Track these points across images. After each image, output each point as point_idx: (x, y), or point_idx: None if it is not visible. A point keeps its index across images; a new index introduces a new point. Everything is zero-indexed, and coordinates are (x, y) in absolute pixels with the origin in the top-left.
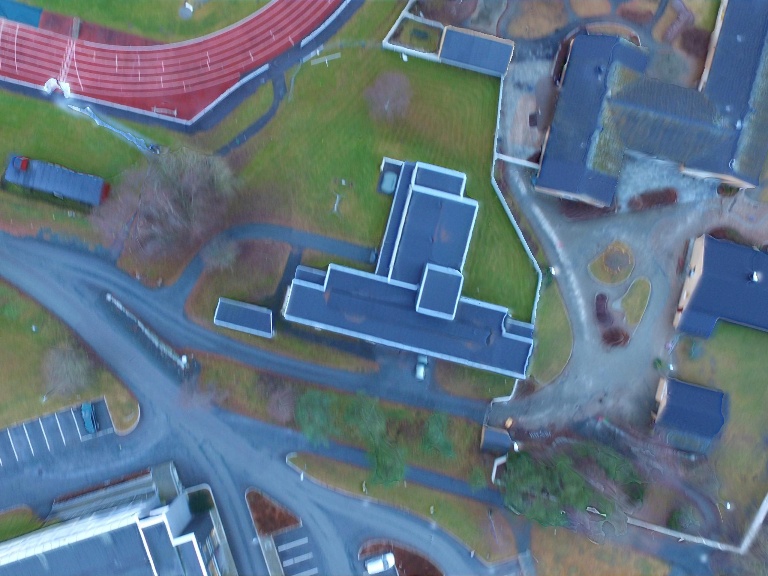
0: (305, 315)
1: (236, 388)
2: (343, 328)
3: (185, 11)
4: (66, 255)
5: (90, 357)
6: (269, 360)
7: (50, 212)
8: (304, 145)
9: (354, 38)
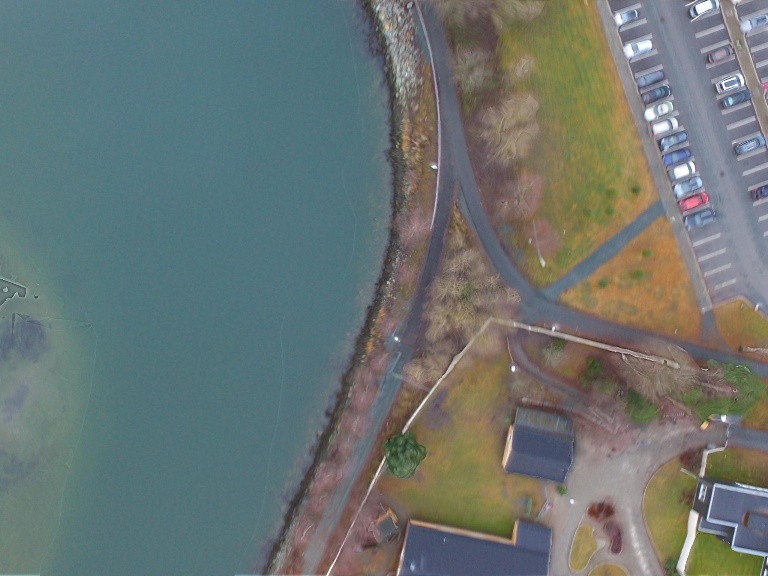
0: None
1: None
2: None
3: None
4: None
5: None
6: None
7: None
8: None
9: None
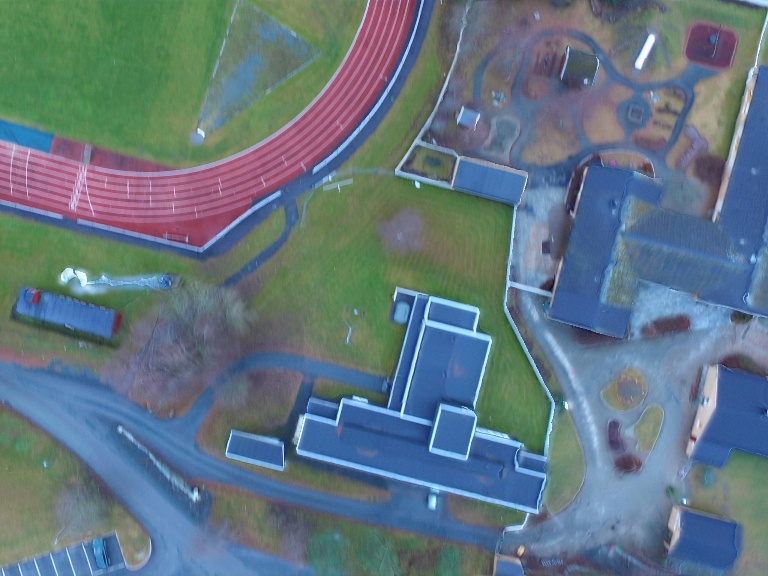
0: (317, 449)
1: (248, 520)
2: (355, 463)
3: (197, 137)
4: (77, 387)
5: (101, 490)
6: (281, 490)
7: (61, 343)
8: (316, 273)
9: (366, 164)
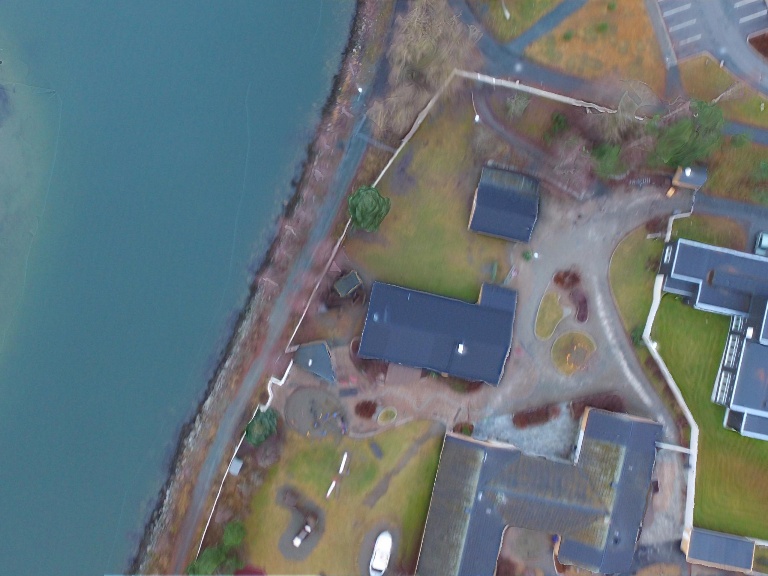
0: None
1: None
2: None
3: None
4: None
5: None
6: None
7: None
8: None
9: None
